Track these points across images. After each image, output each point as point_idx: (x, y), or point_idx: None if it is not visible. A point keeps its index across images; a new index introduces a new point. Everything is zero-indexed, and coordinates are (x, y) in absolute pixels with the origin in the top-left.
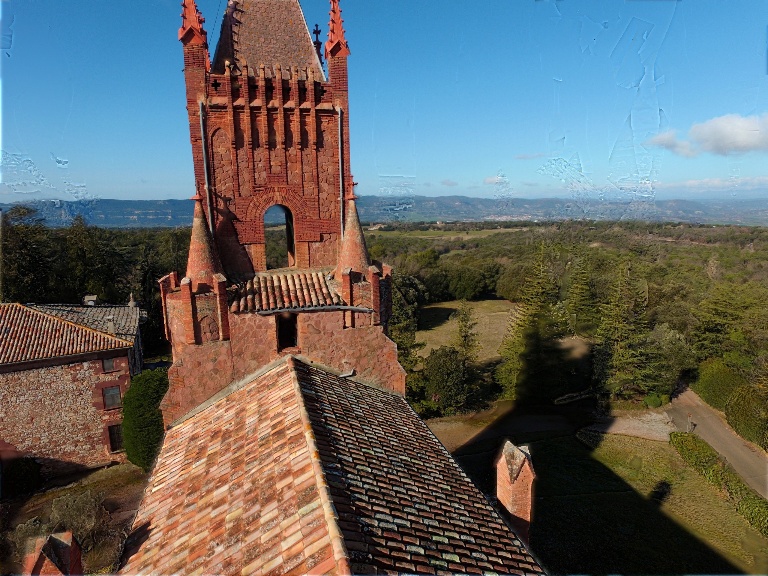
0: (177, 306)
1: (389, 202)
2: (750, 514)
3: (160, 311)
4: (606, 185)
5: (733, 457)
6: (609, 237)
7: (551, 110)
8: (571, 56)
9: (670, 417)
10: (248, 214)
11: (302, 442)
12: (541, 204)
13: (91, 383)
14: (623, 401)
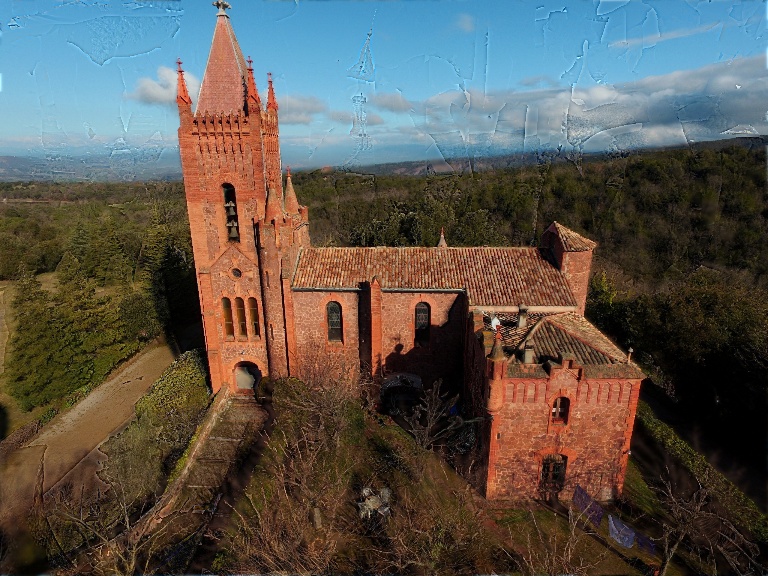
0: None
1: None
2: None
3: None
4: (86, 150)
5: None
6: None
7: (35, 73)
8: None
9: None
10: None
11: (371, 250)
12: (163, 172)
13: None
14: None
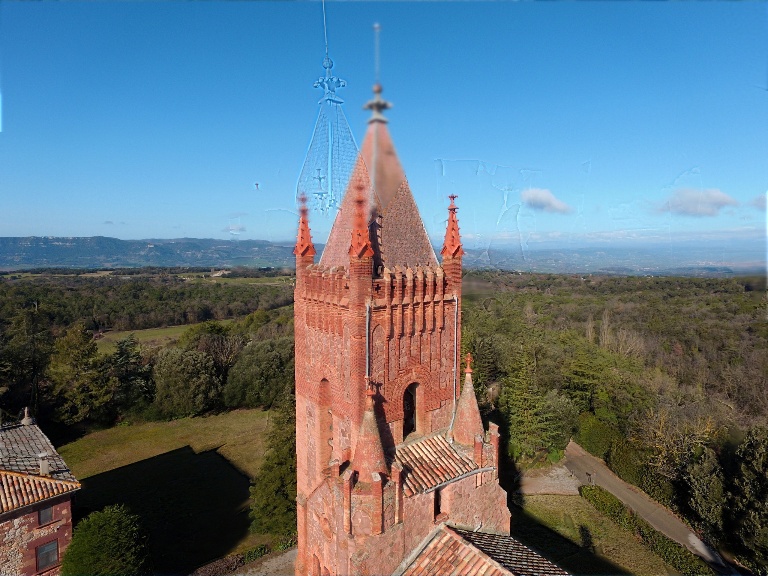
0: (366, 501)
1: (284, 272)
2: (664, 553)
3: (8, 409)
4: (474, 258)
5: (626, 501)
6: (503, 316)
7: (435, 197)
8: (466, 165)
9: (570, 470)
10: (393, 395)
11: None
12: (469, 298)
13: (22, 544)
14: (531, 460)
